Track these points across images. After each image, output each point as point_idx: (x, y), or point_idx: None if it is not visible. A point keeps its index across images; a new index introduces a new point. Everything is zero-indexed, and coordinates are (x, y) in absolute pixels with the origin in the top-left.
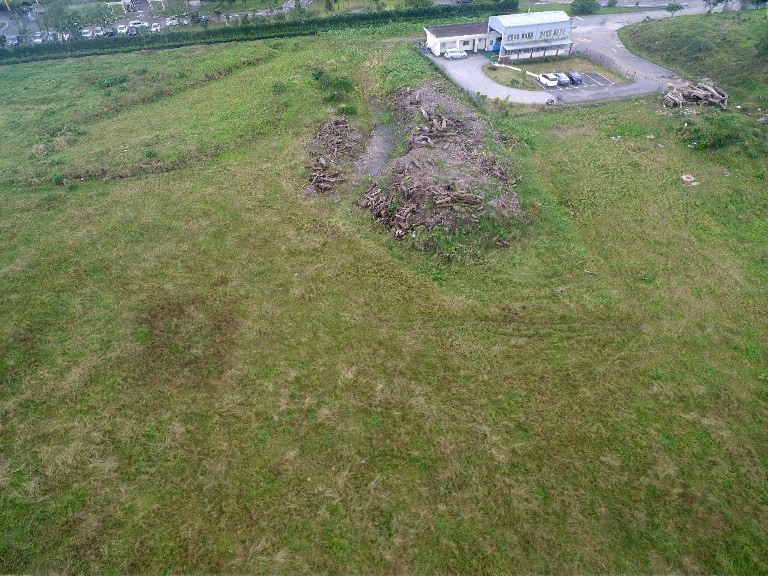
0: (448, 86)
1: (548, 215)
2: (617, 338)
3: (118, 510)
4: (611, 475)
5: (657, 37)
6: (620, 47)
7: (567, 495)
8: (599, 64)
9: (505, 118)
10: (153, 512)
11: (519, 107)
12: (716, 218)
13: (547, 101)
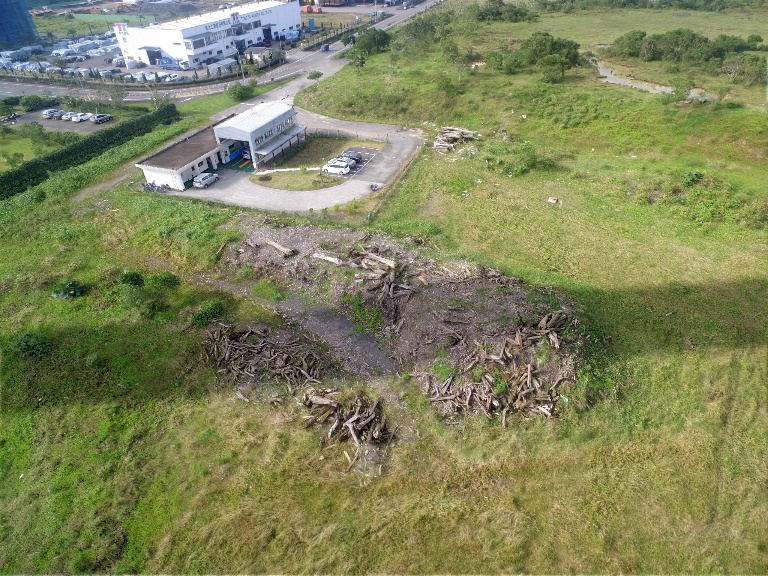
0: (270, 217)
1: (570, 288)
2: (767, 350)
3: None
4: None
5: (351, 101)
6: (326, 118)
7: None
8: (342, 138)
9: (374, 221)
10: None
11: (360, 205)
12: (614, 219)
13: (372, 188)
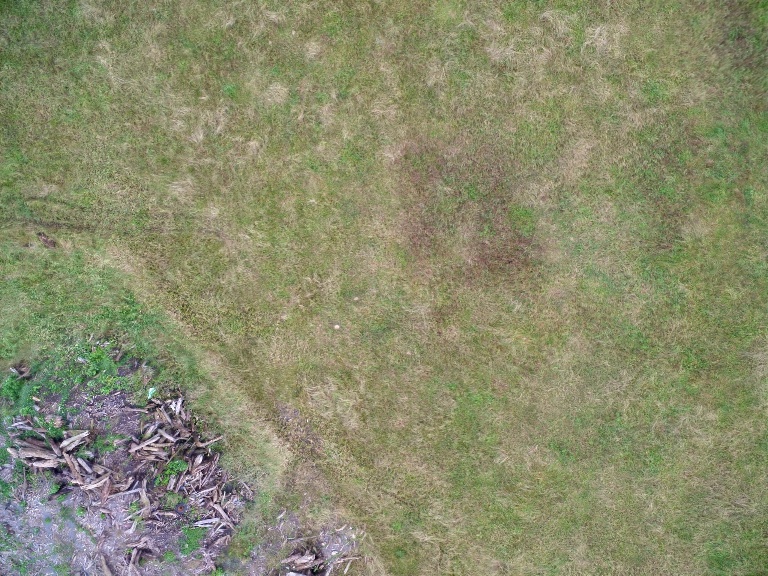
0: None
1: None
2: None
3: (467, 2)
4: (4, 26)
5: None
6: None
7: (51, 8)
8: None
9: None
10: (434, 2)
11: None
12: None
13: None
